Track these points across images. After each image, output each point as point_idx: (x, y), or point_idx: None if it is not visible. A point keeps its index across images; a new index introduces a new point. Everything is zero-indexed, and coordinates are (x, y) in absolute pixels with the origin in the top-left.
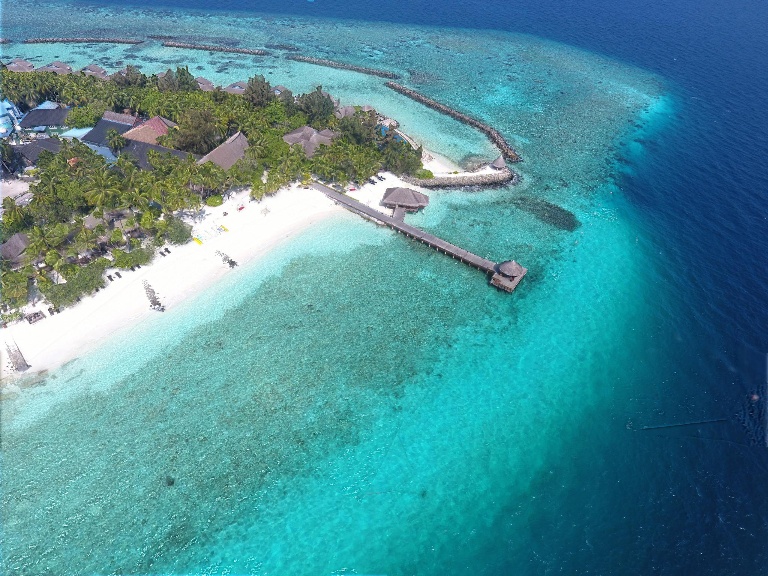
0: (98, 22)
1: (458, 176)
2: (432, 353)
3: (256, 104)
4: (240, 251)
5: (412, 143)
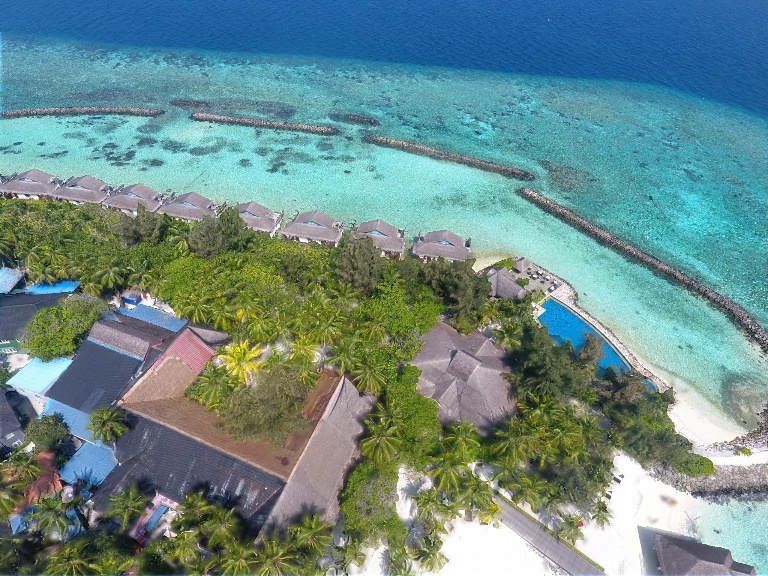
0: (105, 77)
1: (756, 463)
2: None
3: (357, 285)
4: None
5: (625, 353)
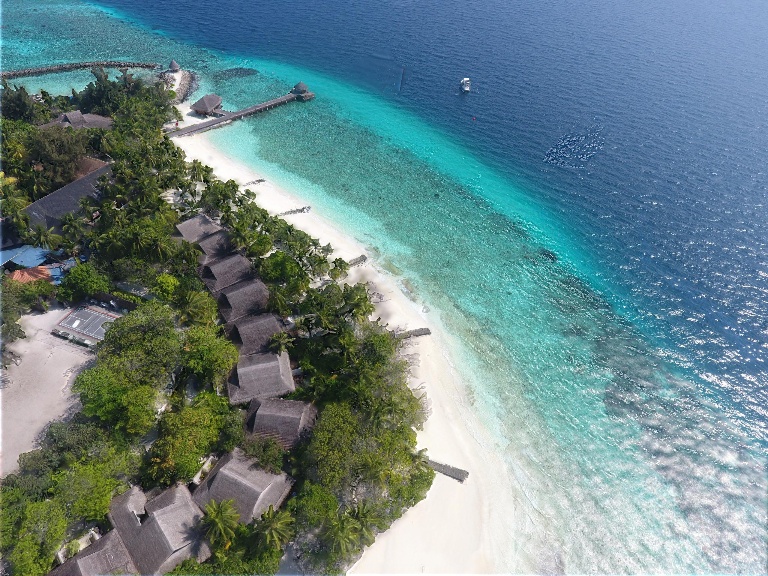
0: None
1: (178, 85)
2: (355, 126)
3: None
4: (245, 177)
5: None
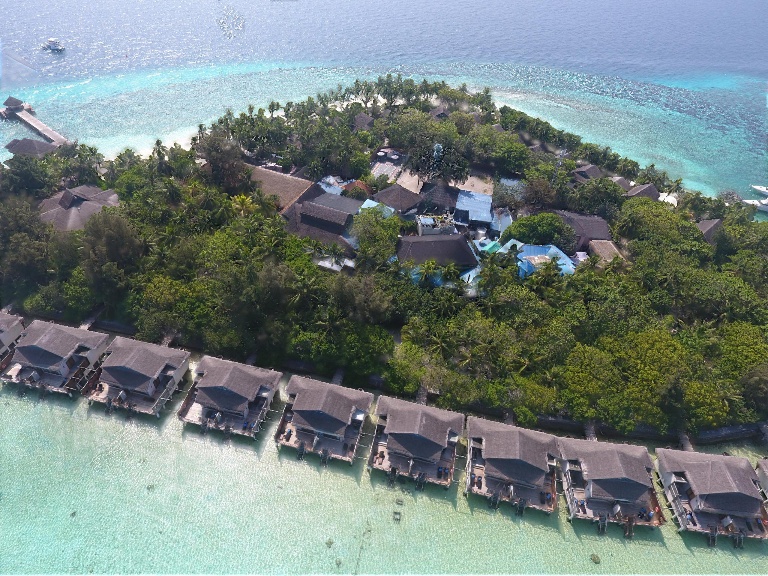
0: None
1: None
2: None
3: None
4: None
5: None
